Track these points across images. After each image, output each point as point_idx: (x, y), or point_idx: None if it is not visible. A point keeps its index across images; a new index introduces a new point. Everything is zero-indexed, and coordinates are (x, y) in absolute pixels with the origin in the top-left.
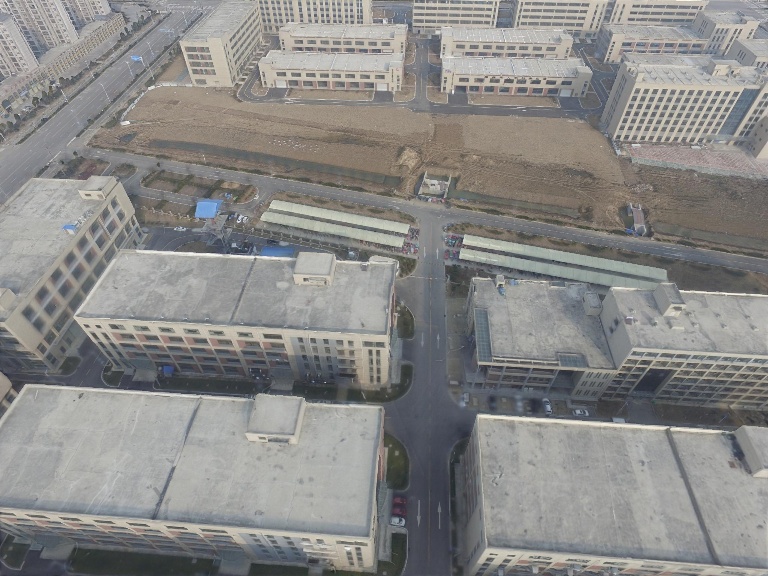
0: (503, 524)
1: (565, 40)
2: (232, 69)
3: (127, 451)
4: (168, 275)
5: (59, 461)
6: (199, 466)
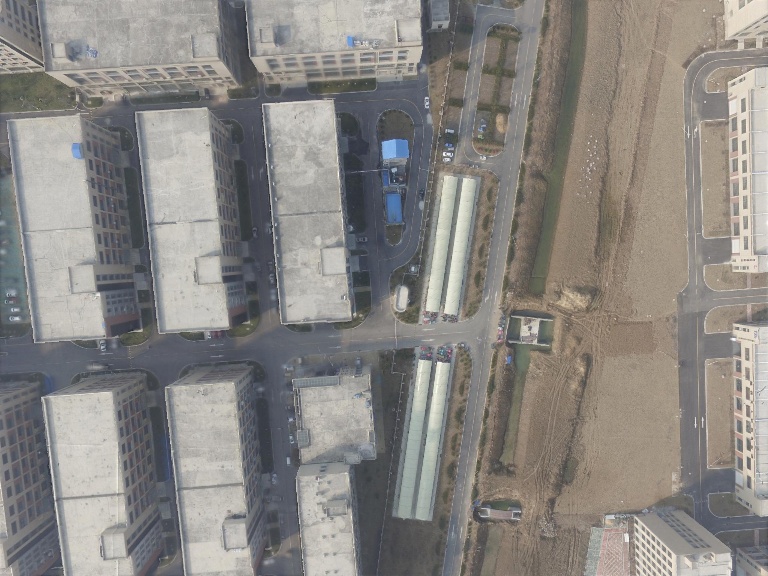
0: (179, 395)
1: None
2: (756, 27)
3: (180, 192)
4: (314, 151)
5: (169, 158)
6: (180, 236)
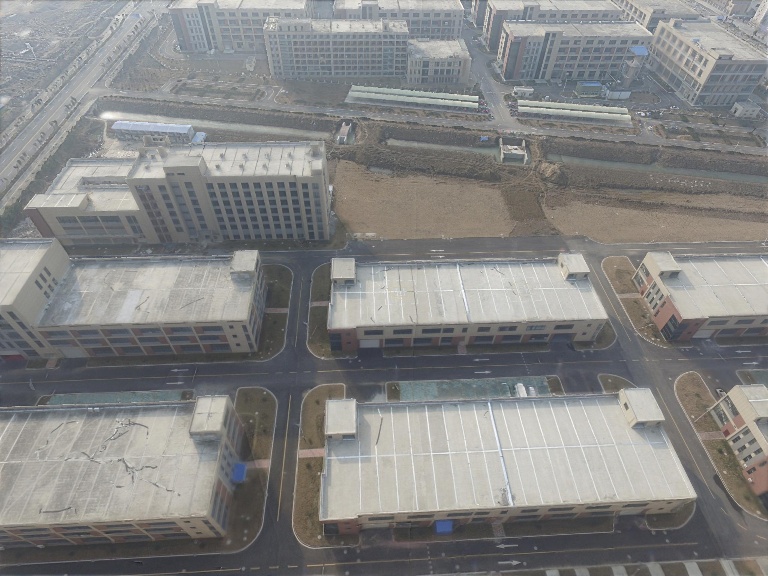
0: None
1: (348, 399)
2: None
3: (570, 5)
4: None
5: None
6: None
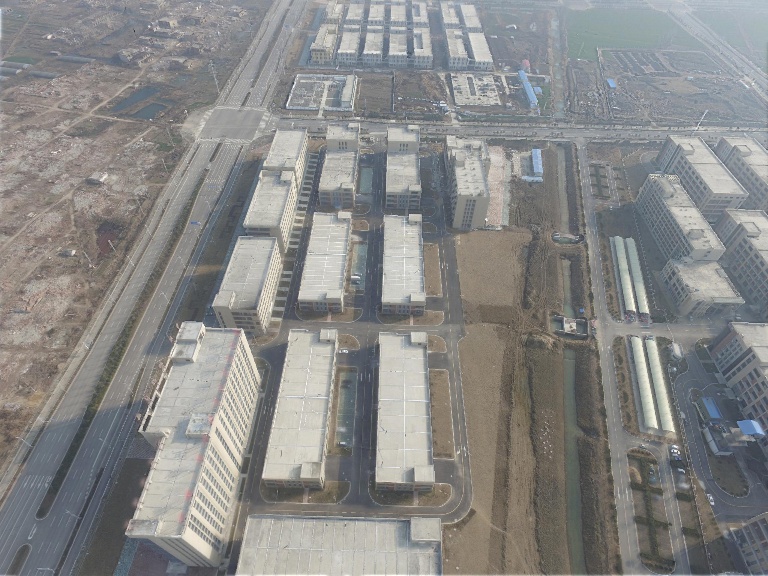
0: None
1: None
2: None
3: None
4: None
5: None
6: None
